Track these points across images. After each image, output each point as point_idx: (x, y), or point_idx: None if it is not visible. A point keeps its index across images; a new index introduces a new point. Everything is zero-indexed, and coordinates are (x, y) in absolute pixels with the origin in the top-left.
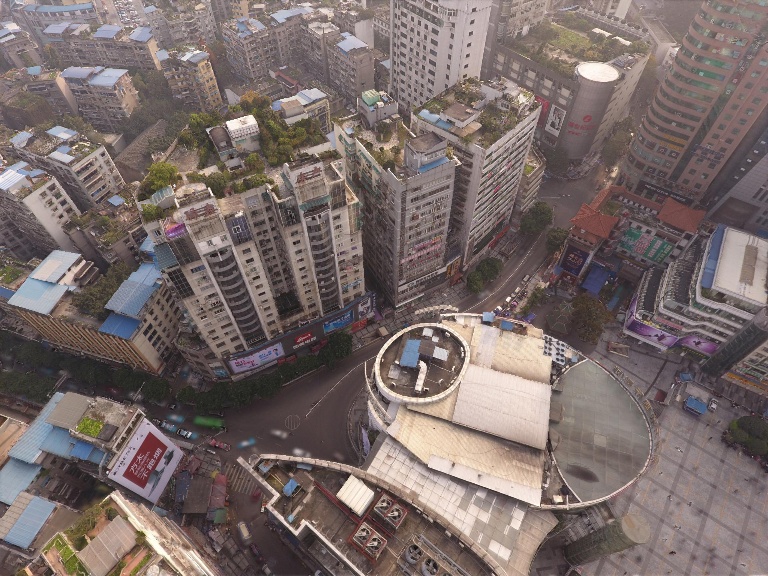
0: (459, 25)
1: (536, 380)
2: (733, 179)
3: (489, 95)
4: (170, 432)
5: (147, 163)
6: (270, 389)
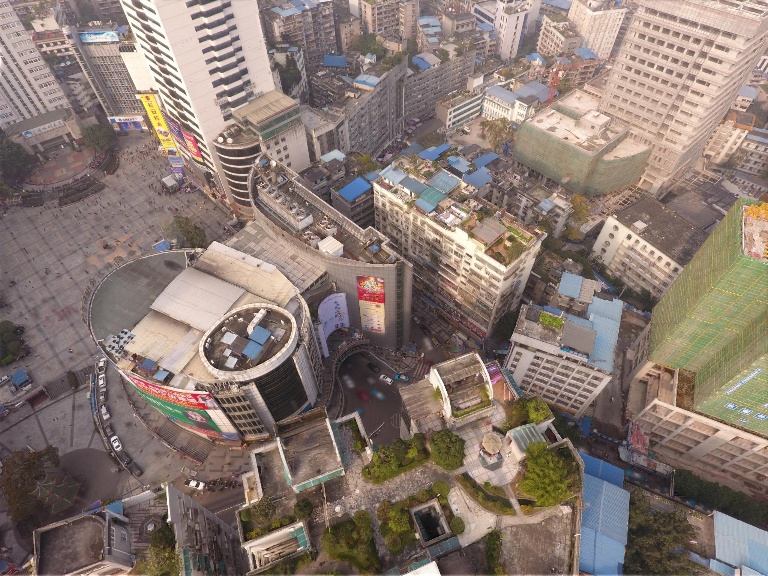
0: None
1: (159, 315)
2: None
3: None
4: None
5: None
6: None
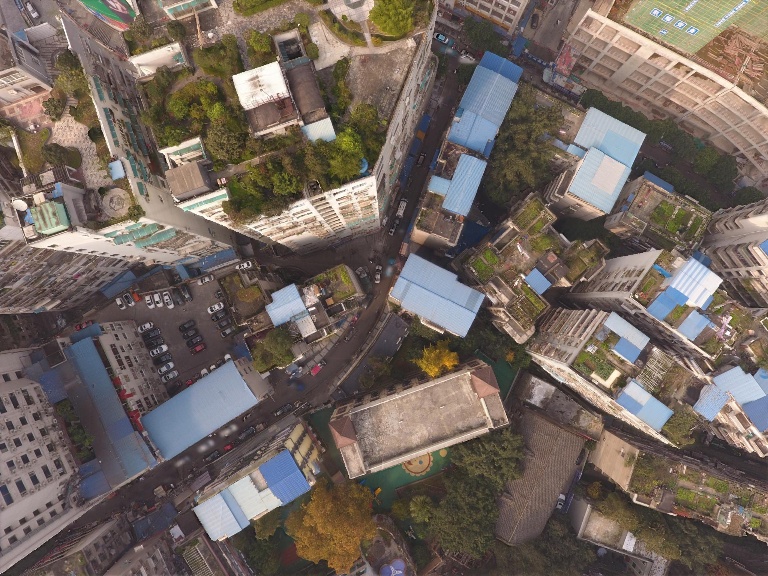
0: None
1: None
2: None
3: None
4: (456, 43)
5: (521, 433)
6: None
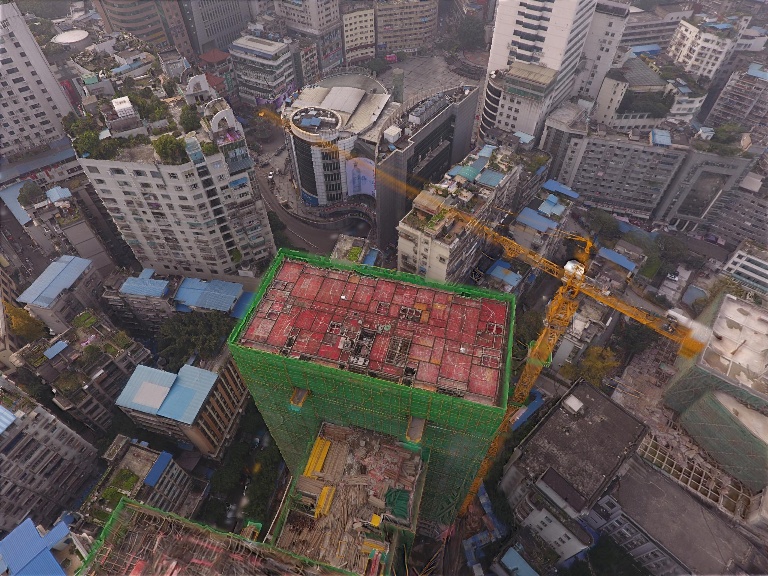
0: (17, 31)
1: None
2: (194, 35)
3: (107, 49)
4: None
5: None
6: (302, 248)
